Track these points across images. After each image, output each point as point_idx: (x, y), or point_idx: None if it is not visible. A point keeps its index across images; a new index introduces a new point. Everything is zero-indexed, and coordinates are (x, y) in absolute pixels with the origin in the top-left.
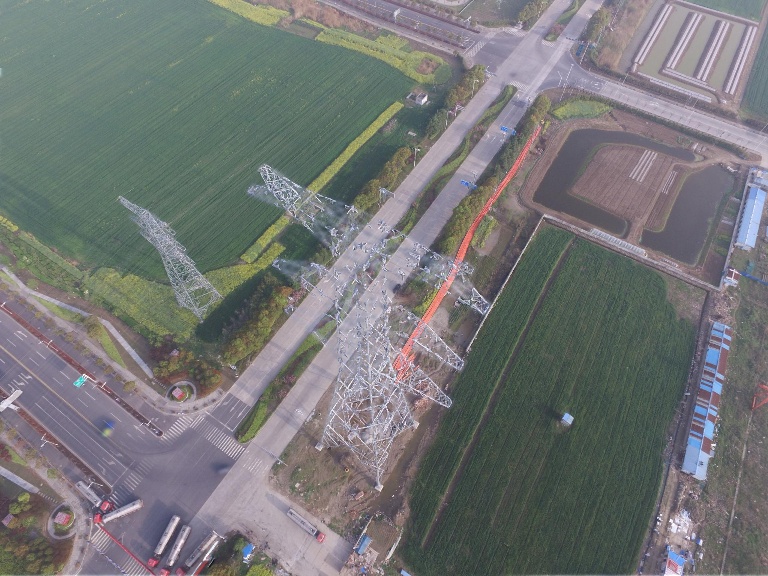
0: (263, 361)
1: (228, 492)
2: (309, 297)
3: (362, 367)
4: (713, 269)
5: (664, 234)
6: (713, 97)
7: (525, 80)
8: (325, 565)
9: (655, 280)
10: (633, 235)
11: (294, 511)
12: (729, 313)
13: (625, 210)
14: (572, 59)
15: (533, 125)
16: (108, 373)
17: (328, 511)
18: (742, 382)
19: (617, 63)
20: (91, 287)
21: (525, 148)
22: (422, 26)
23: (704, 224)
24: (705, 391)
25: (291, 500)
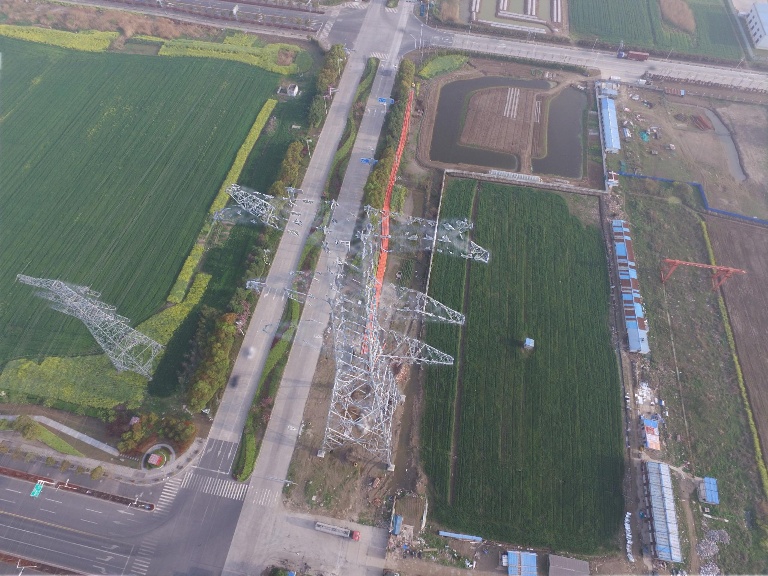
0: (232, 394)
1: (247, 534)
2: (255, 316)
3: (333, 364)
4: (596, 176)
5: (549, 158)
6: (546, 28)
7: (383, 49)
8: (369, 559)
9: (556, 200)
10: (525, 166)
11: (321, 523)
12: (620, 209)
13: (511, 146)
14: (418, 20)
15: (407, 90)
16: (65, 469)
17: (353, 509)
18: (649, 263)
19: (458, 15)
20: (5, 387)
21: (406, 113)
22: (266, 18)
23: (576, 140)
24: (625, 280)
25: (313, 514)
